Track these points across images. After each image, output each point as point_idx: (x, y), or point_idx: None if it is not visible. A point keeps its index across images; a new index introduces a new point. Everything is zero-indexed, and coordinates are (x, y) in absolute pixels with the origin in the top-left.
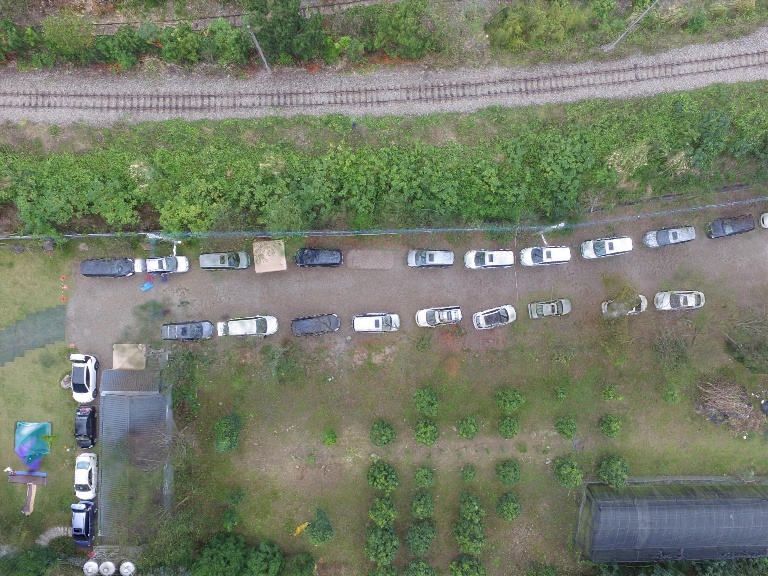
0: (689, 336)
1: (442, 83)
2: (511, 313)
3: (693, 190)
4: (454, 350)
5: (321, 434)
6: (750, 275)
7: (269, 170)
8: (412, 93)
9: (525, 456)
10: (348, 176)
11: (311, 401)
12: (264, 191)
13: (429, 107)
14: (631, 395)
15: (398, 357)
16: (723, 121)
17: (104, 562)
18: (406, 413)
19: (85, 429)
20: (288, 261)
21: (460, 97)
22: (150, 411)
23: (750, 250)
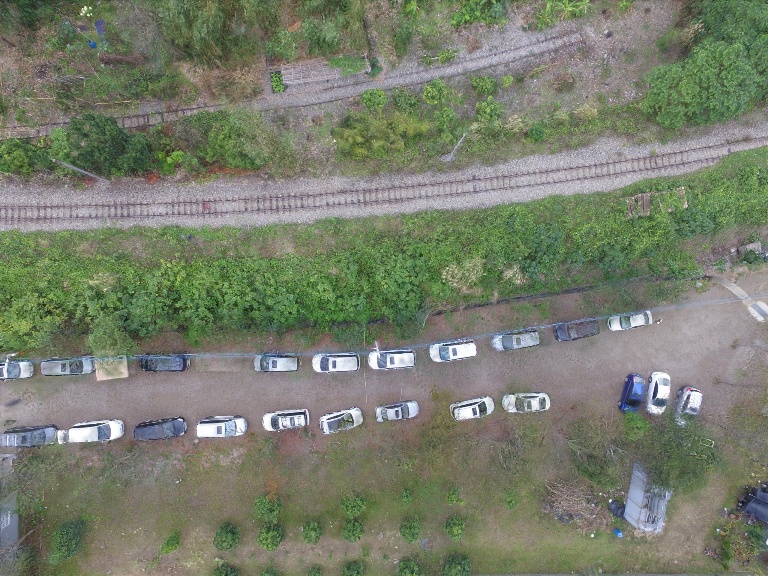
0: (538, 436)
1: (280, 194)
2: (357, 417)
3: (543, 292)
4: (302, 452)
5: None
6: (599, 376)
7: (100, 285)
8: (250, 204)
9: (373, 556)
10: (184, 288)
11: (159, 503)
12: (96, 306)
13: (267, 218)
14: (480, 495)
15: (246, 459)
16: (554, 237)
17: None
18: (254, 514)
19: None
20: (136, 364)
21: (298, 208)
22: None
23: (599, 351)
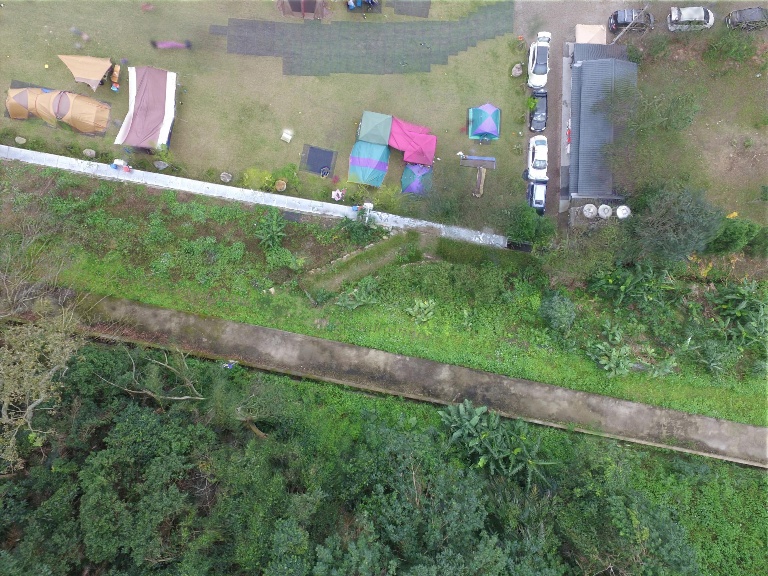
0: None
1: None
2: None
3: None
4: None
5: (749, 128)
6: None
7: None
8: None
9: None
10: None
11: (739, 96)
12: None
13: None
14: None
15: None
16: None
17: (603, 204)
18: None
19: (545, 107)
20: None
21: None
22: (627, 76)
23: None
